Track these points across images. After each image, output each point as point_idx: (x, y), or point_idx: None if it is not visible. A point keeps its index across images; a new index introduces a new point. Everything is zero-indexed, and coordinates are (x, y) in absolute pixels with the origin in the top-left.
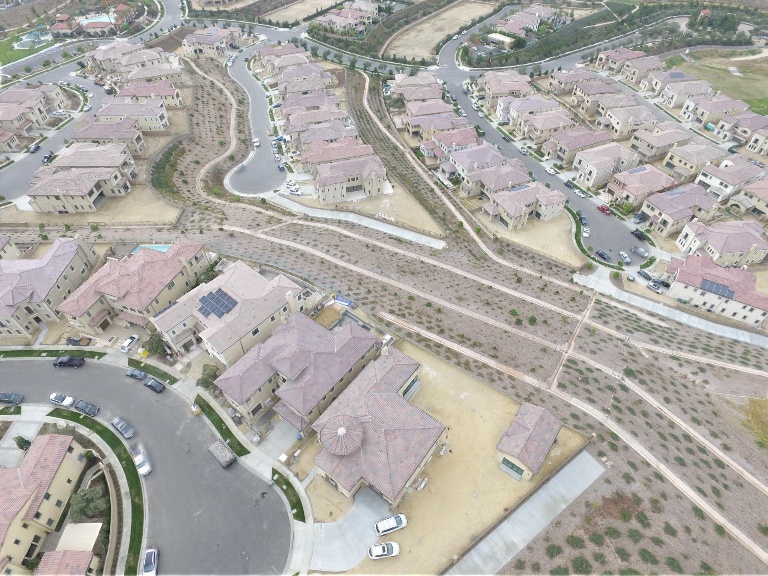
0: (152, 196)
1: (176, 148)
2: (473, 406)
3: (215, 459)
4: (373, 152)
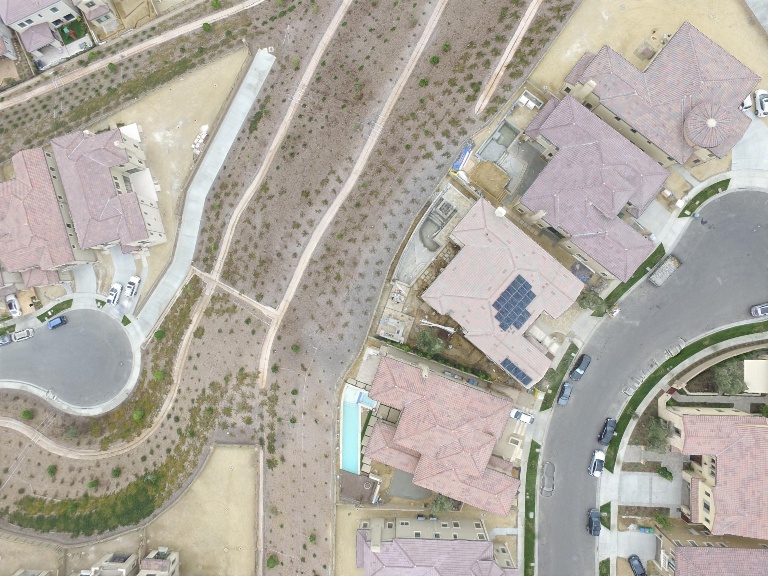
0: (180, 506)
1: (20, 515)
2: (618, 7)
3: None
4: (39, 149)
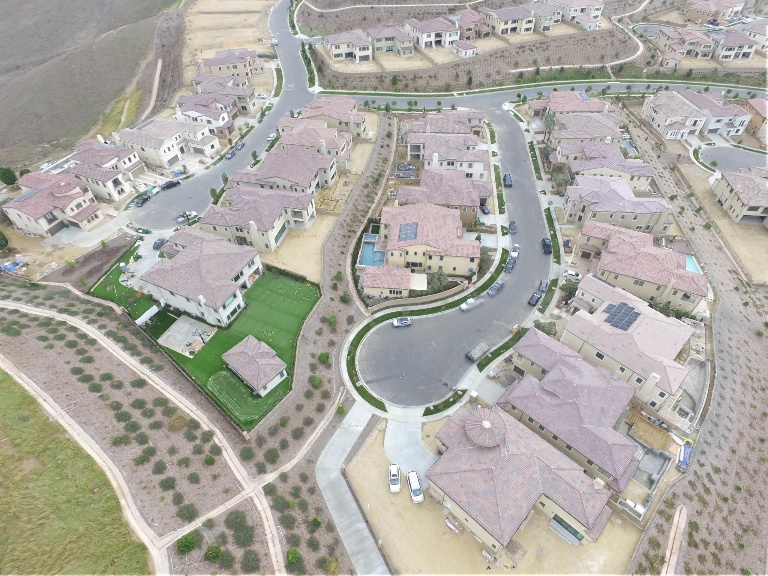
0: None
1: None
2: None
3: (474, 348)
4: None
